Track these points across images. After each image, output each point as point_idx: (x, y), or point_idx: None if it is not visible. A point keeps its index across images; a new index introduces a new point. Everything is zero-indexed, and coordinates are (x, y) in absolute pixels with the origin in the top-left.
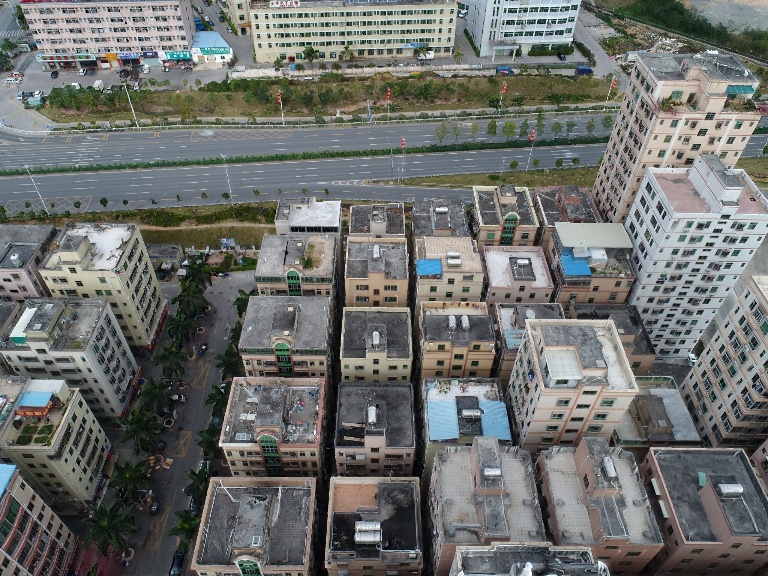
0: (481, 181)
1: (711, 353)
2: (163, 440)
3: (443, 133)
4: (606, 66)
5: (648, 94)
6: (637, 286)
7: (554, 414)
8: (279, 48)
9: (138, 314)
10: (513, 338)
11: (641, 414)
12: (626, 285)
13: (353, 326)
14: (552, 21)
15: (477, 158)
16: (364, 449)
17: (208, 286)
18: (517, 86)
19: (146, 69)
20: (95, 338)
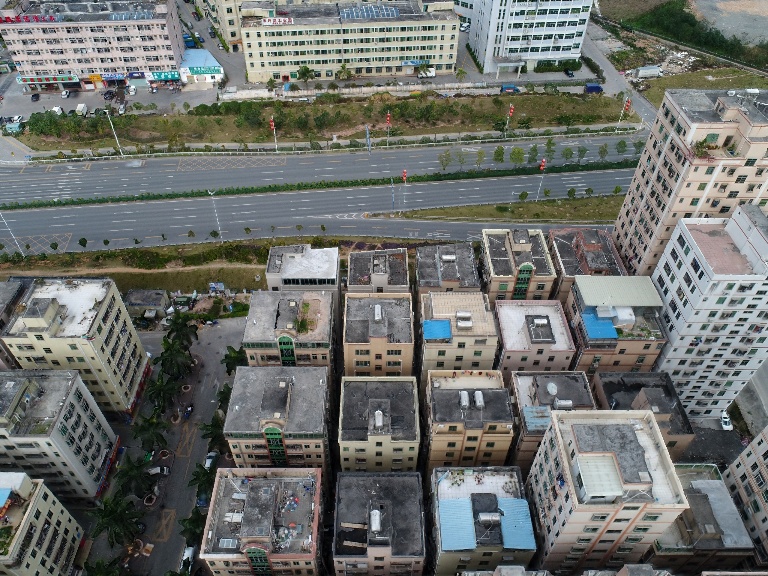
0: (488, 213)
1: (764, 445)
2: (143, 521)
3: (447, 161)
4: (616, 83)
5: (680, 136)
6: (668, 348)
7: (588, 528)
8: (272, 67)
9: (115, 378)
10: (533, 417)
11: (684, 514)
12: (656, 347)
13: (353, 399)
14: (559, 36)
15: (483, 187)
16: (367, 558)
17: (194, 341)
18: (523, 106)
19: (132, 90)
20: (63, 418)
